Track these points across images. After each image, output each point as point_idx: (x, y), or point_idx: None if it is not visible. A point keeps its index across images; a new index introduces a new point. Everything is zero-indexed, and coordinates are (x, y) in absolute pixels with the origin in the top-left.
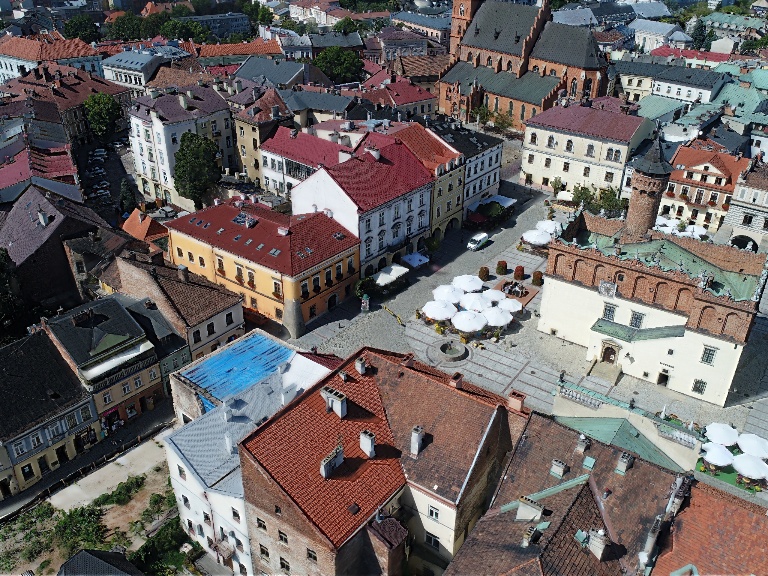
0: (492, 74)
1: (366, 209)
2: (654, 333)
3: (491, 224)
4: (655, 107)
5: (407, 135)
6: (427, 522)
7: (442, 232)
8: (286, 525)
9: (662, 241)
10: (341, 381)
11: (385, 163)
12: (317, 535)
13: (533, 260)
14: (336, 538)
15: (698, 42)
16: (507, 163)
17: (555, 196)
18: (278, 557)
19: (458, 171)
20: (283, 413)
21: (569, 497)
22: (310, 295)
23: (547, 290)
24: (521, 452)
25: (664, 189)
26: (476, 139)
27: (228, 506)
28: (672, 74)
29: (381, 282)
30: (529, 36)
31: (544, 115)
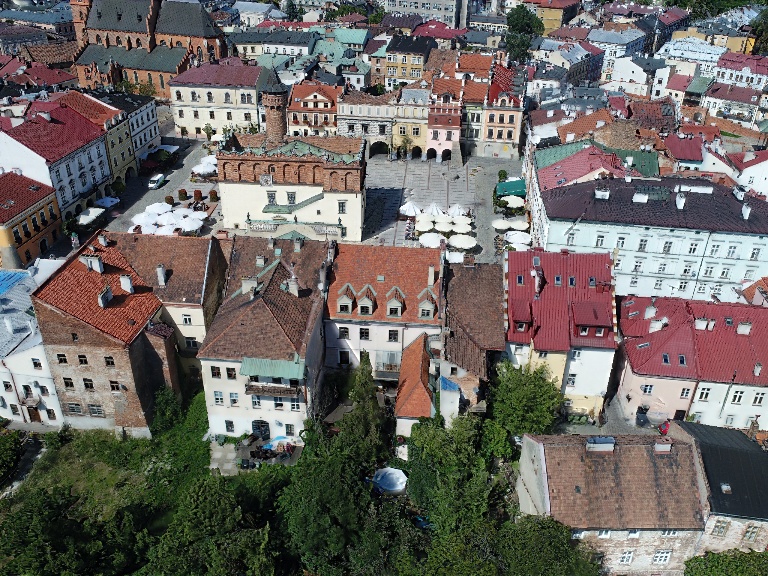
0: (124, 52)
1: (53, 160)
2: (305, 203)
3: (163, 168)
4: (269, 62)
5: (68, 101)
6: (184, 329)
7: (123, 180)
8: (84, 347)
9: (295, 142)
10: (92, 252)
11: (57, 123)
12: (111, 340)
13: (206, 186)
14: (125, 339)
15: (293, 18)
16: (161, 124)
17: (209, 140)
18: (82, 380)
19: (123, 125)
20: (56, 274)
21: (271, 272)
22: (23, 240)
23: (223, 194)
24: (235, 260)
25: (286, 103)
26: (131, 99)
27: (28, 360)
28: (276, 37)
29: (84, 222)
30: (150, 14)
31: (182, 75)
